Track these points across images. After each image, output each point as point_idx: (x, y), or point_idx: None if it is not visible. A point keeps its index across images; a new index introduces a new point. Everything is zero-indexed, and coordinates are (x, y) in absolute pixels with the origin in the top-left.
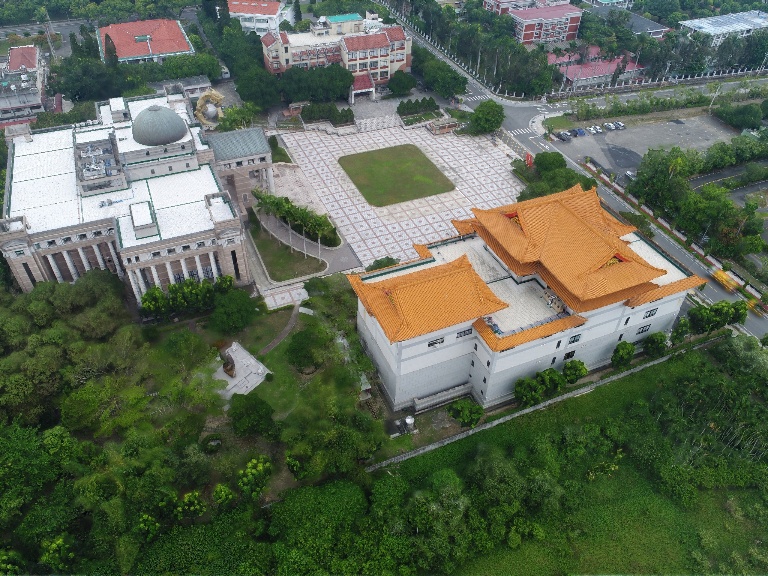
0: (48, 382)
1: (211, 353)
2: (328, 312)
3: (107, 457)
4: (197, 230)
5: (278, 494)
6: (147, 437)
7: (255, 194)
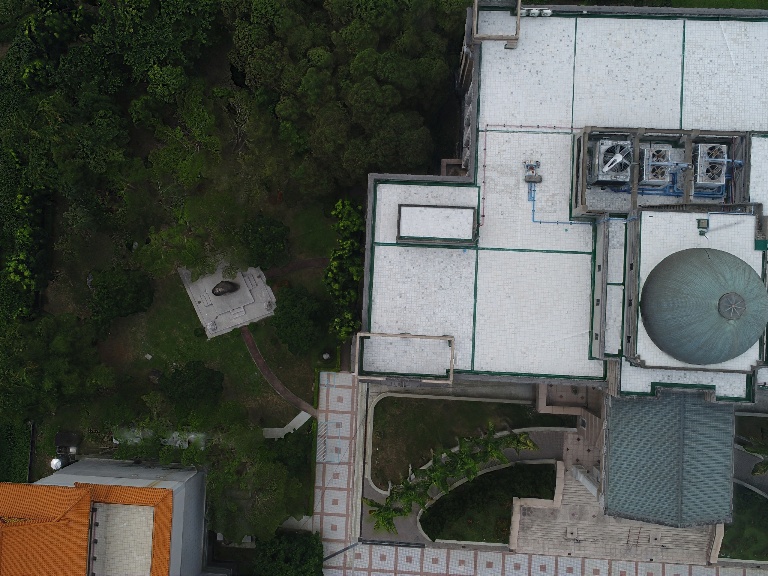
0: (252, 73)
1: (231, 271)
2: (222, 443)
3: (96, 127)
4: (384, 305)
5: (33, 290)
6: (101, 171)
7: (510, 436)
